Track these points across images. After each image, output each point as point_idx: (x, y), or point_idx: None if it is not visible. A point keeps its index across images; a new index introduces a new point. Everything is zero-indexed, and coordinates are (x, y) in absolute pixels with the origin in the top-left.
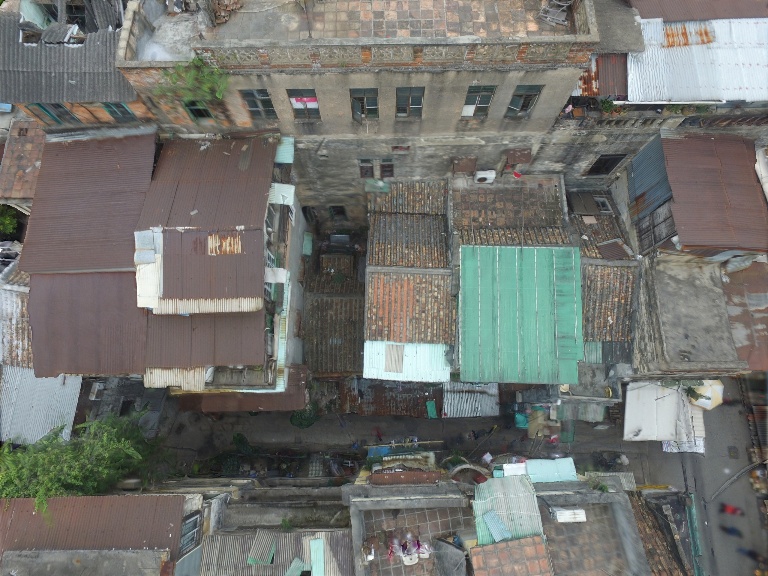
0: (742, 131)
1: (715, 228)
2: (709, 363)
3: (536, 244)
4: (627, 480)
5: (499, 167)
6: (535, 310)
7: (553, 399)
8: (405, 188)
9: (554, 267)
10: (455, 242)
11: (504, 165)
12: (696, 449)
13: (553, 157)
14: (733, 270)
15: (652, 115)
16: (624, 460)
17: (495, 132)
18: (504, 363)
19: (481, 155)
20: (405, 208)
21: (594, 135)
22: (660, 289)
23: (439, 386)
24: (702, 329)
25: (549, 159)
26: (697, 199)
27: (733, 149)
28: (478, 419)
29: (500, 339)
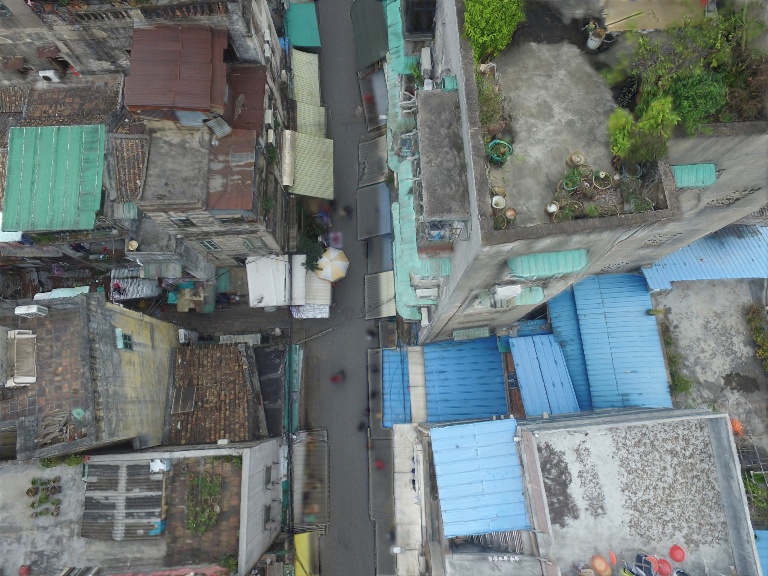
0: (205, 21)
1: (158, 93)
2: (167, 200)
3: (72, 124)
4: (254, 340)
5: (59, 67)
6: (66, 174)
7: (133, 259)
8: (1, 92)
9: (83, 140)
10: (8, 125)
11: (61, 65)
12: (323, 315)
13: (89, 55)
14: (221, 135)
15: (109, 8)
16: (277, 331)
17: (5, 29)
18: (36, 216)
19: (27, 55)
20: (3, 108)
21: (91, 30)
22: (154, 151)
23: (107, 274)
24: (181, 179)
25: (89, 57)
26: (151, 72)
27: (199, 36)
28: (169, 309)
29: (36, 198)
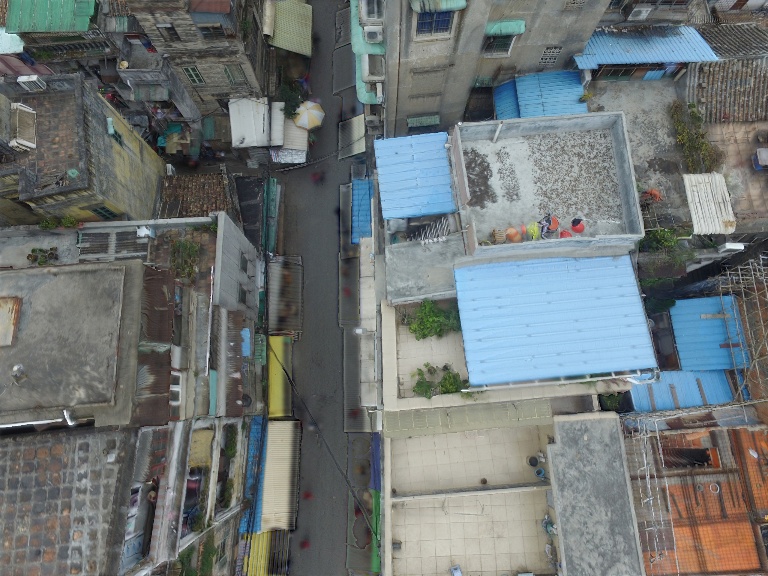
0: None
1: None
2: None
3: None
4: None
5: None
6: None
7: (124, 81)
8: None
9: None
10: None
11: None
12: (300, 160)
13: None
14: None
15: None
16: None
17: None
18: (37, 20)
19: None
20: None
21: None
22: None
23: None
24: None
25: None
26: None
27: None
28: None
29: (36, 5)
